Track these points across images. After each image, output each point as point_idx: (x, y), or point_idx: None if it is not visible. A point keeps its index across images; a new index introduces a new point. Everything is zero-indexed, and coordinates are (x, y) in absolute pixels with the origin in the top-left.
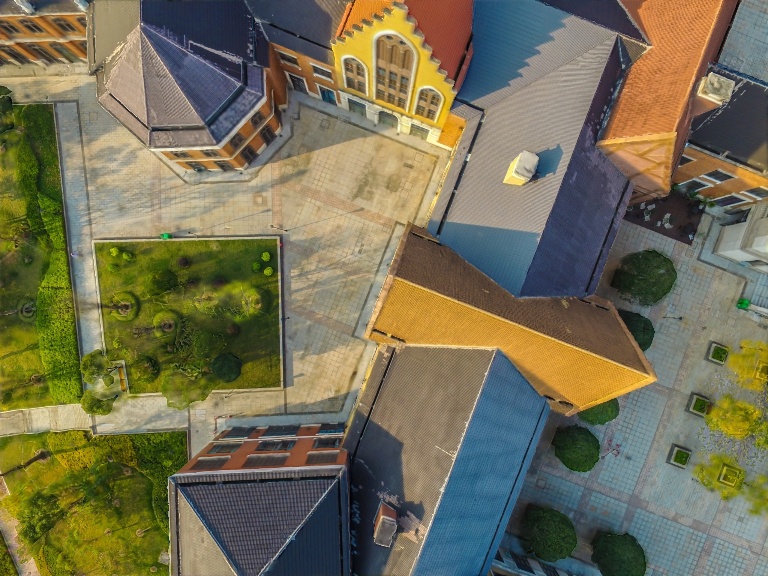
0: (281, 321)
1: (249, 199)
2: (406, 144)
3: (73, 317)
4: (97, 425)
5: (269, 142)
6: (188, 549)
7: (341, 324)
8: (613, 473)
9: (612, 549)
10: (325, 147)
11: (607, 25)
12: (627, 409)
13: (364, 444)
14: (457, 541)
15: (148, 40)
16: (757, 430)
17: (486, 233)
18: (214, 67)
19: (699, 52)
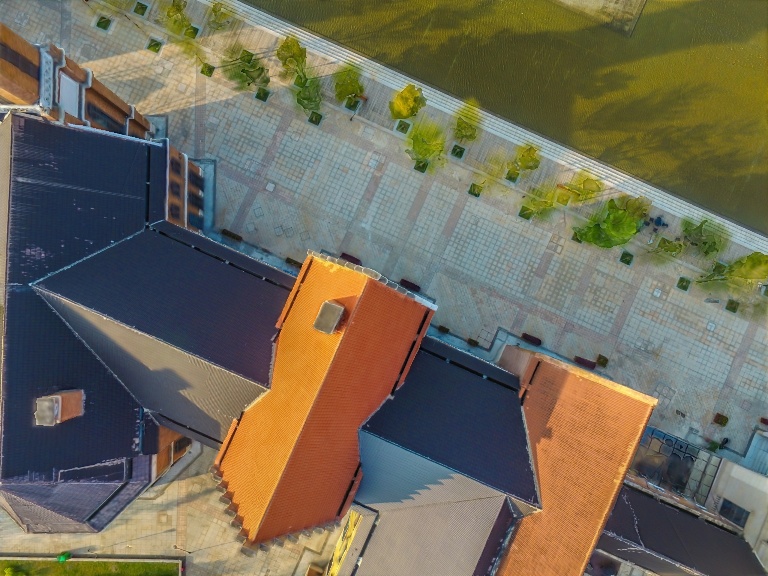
0: None
1: (153, 517)
2: None
3: None
4: None
5: None
6: None
7: None
8: None
9: None
10: None
11: (497, 479)
12: None
13: None
14: None
15: (8, 493)
16: None
17: None
18: (90, 483)
19: (579, 566)
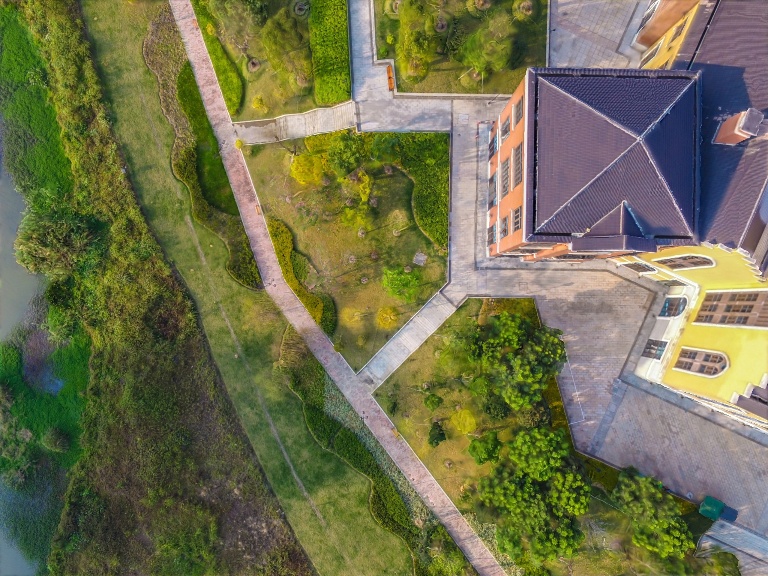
0: (548, 31)
1: None
2: None
3: (346, 15)
4: (362, 123)
5: None
6: (550, 131)
7: (605, 40)
8: None
9: None
10: None
11: None
12: None
13: None
14: None
15: None
16: None
17: None
18: None
19: None
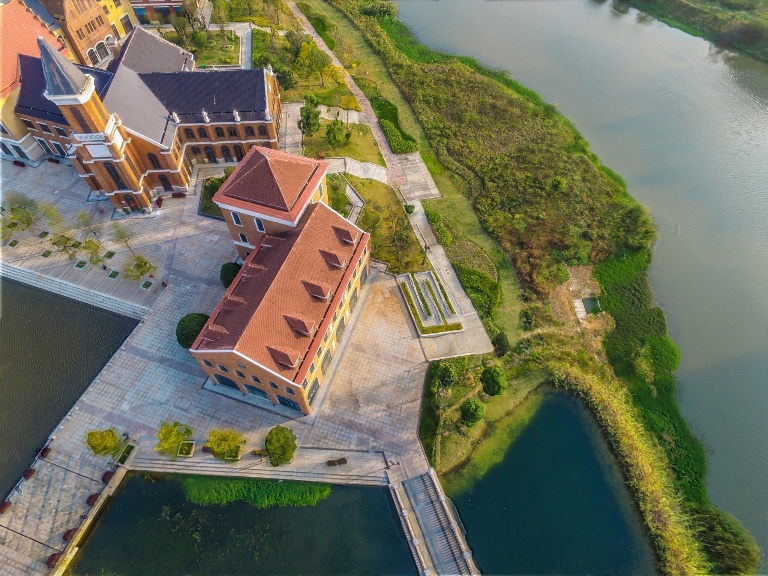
0: None
1: None
2: None
3: None
4: None
5: None
6: None
7: None
8: None
9: None
10: None
11: None
12: None
13: None
14: None
15: None
16: None
17: None
18: None
19: None
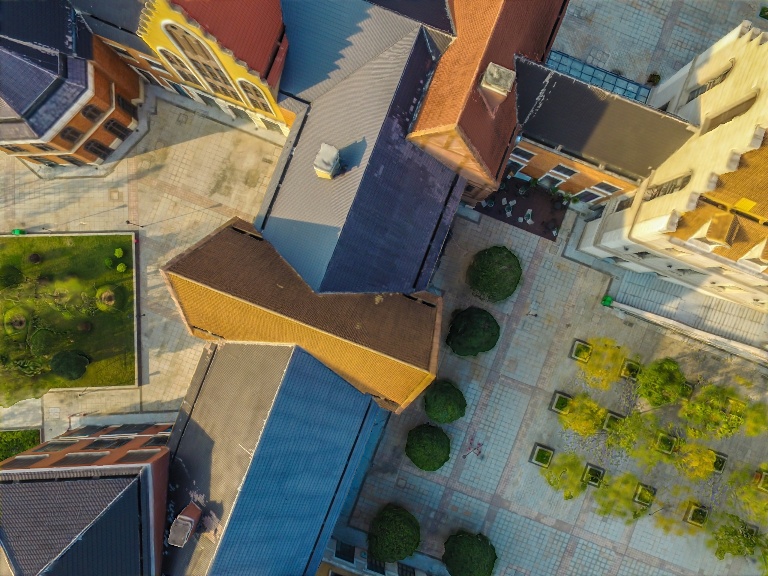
0: (136, 318)
1: (105, 195)
2: (265, 139)
3: None
4: None
5: (124, 137)
6: None
7: None
8: (475, 472)
9: (458, 549)
10: (182, 142)
11: (413, 16)
12: (489, 407)
13: (184, 442)
14: (267, 541)
15: None
16: (622, 429)
17: (299, 228)
18: (22, 59)
19: (485, 42)
